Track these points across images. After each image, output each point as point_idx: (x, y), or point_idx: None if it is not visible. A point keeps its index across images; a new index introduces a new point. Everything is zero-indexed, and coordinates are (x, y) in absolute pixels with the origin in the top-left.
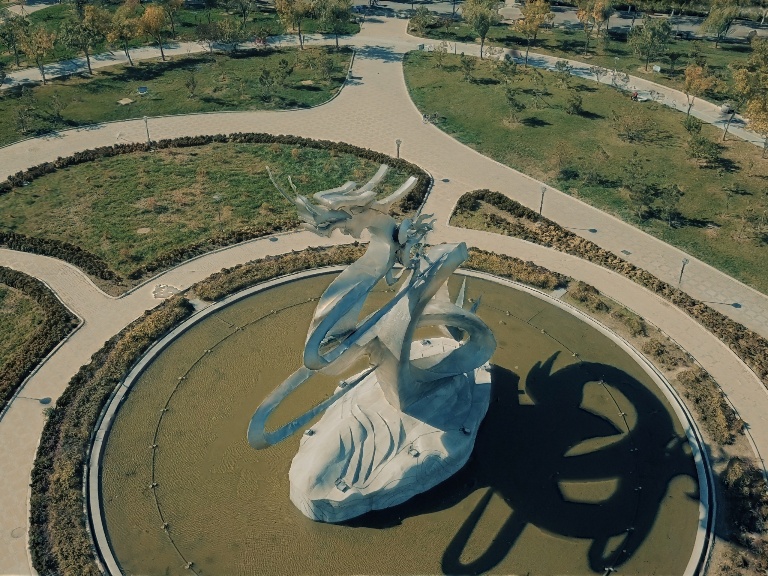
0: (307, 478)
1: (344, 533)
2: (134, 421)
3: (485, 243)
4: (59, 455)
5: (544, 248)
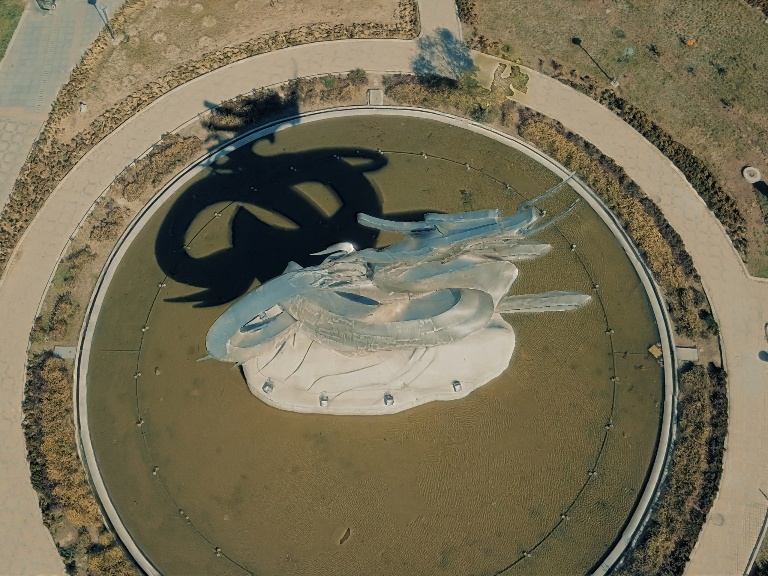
0: (509, 335)
1: None
2: (561, 567)
3: (8, 486)
4: (651, 574)
5: None
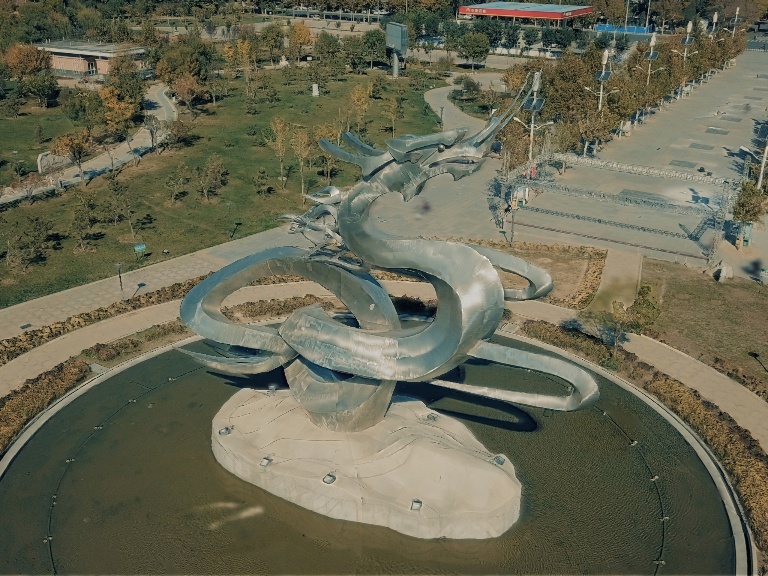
0: (508, 478)
1: (524, 492)
2: None
3: None
4: None
5: None
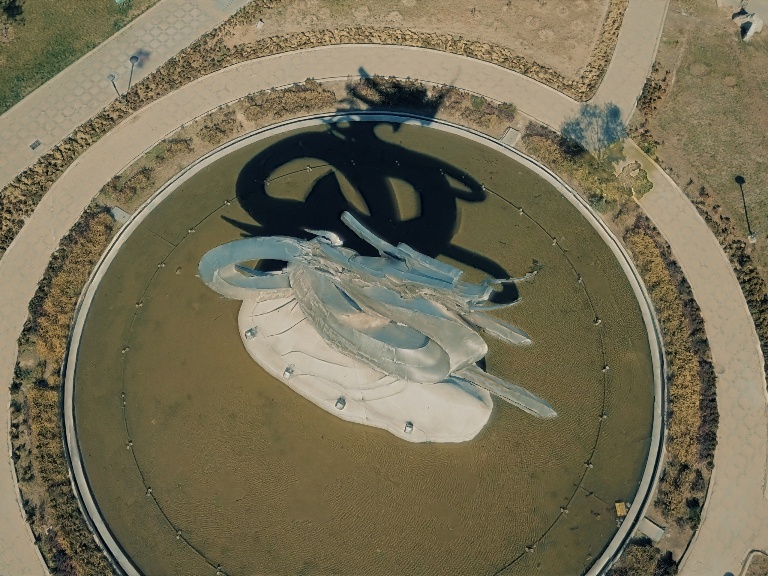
0: (482, 409)
1: None
2: None
3: (13, 295)
4: None
5: (25, 229)
